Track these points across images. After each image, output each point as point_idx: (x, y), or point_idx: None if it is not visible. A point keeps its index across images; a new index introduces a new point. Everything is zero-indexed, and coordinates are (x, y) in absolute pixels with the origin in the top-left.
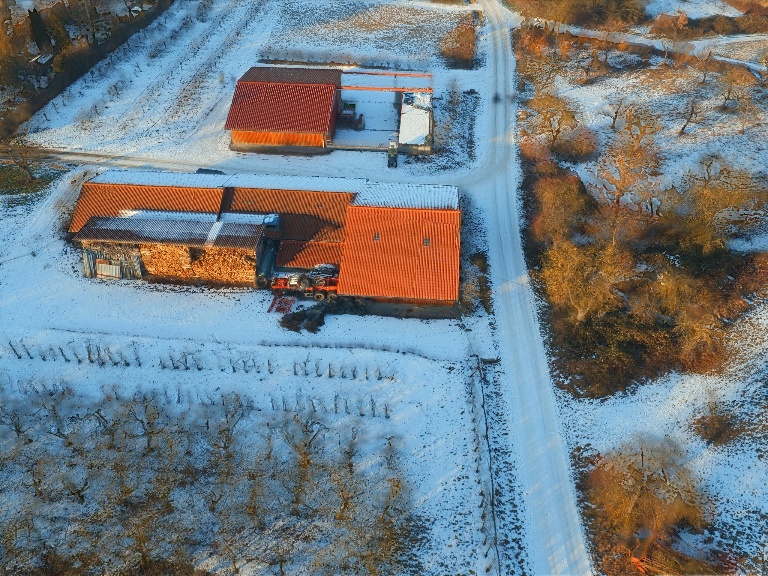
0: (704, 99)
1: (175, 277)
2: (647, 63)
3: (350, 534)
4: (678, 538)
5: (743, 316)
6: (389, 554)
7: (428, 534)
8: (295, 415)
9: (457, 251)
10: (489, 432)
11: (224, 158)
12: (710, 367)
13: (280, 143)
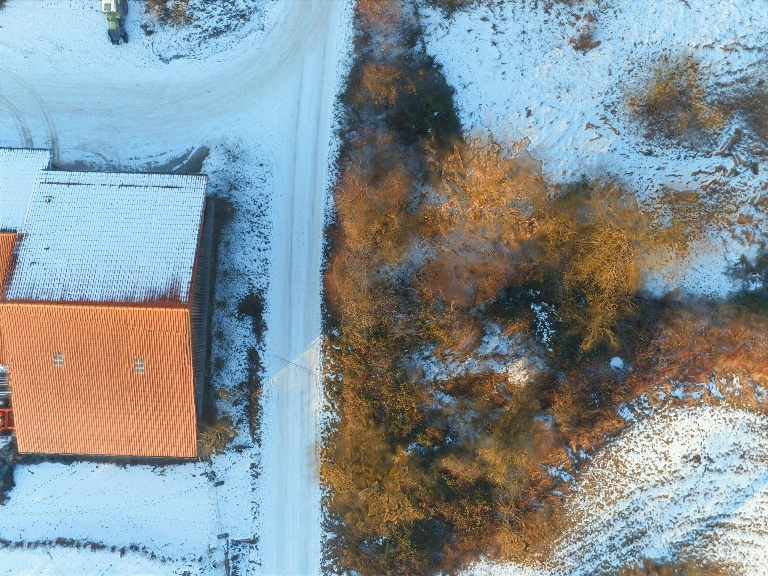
0: None
1: None
2: None
3: None
4: None
5: (610, 445)
6: None
7: None
8: None
9: (189, 379)
10: None
11: None
12: (533, 549)
13: None
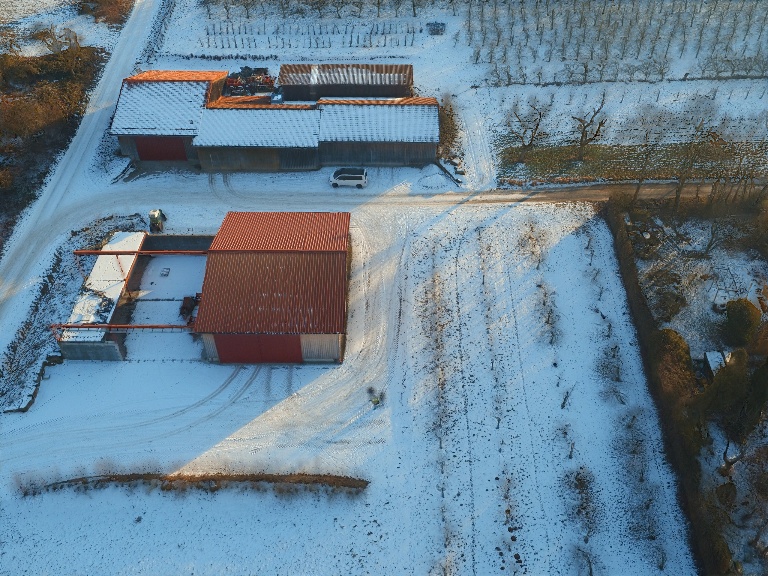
0: None
1: None
2: None
3: (230, 1)
4: (95, 7)
5: None
6: None
7: None
8: None
9: None
10: None
11: None
12: None
13: None
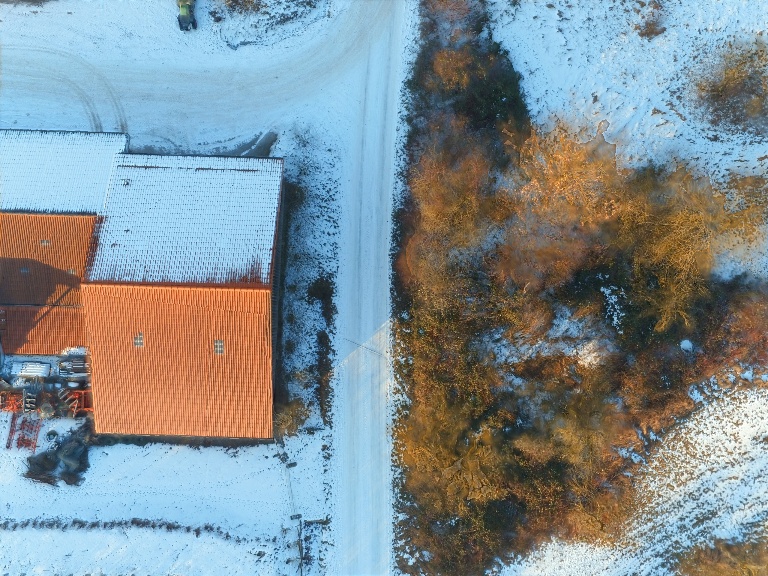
0: None
1: None
2: None
3: None
4: None
5: (680, 427)
6: None
7: None
8: None
9: (268, 360)
10: None
11: None
12: None
13: None
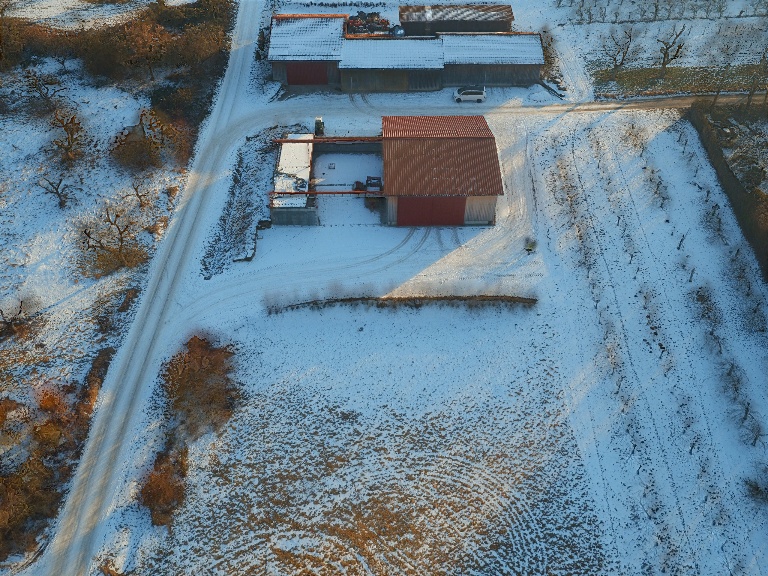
0: None
1: None
2: None
3: None
4: None
5: None
6: None
7: None
8: None
9: None
10: None
11: None
12: None
13: None
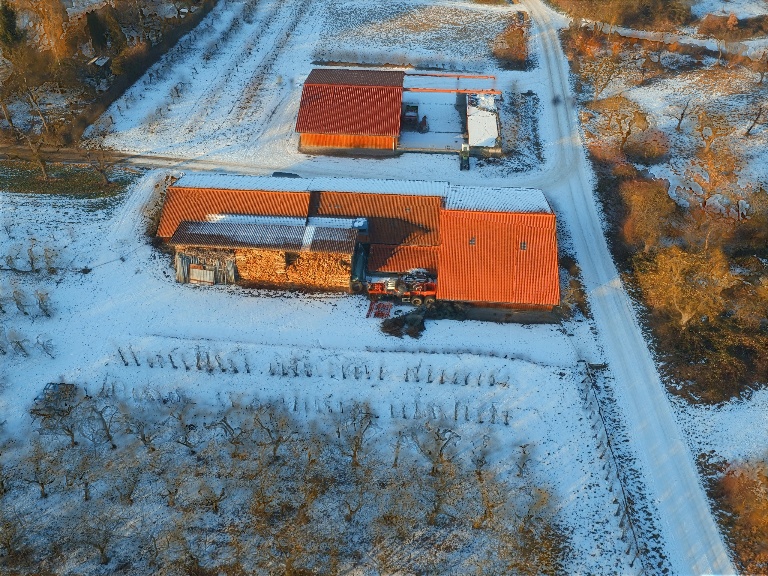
0: (764, 100)
1: (268, 282)
2: (700, 64)
3: (491, 544)
4: None
5: None
6: (534, 564)
7: (569, 543)
8: (426, 423)
9: (555, 255)
10: (610, 439)
11: (295, 161)
12: None
13: (349, 146)
